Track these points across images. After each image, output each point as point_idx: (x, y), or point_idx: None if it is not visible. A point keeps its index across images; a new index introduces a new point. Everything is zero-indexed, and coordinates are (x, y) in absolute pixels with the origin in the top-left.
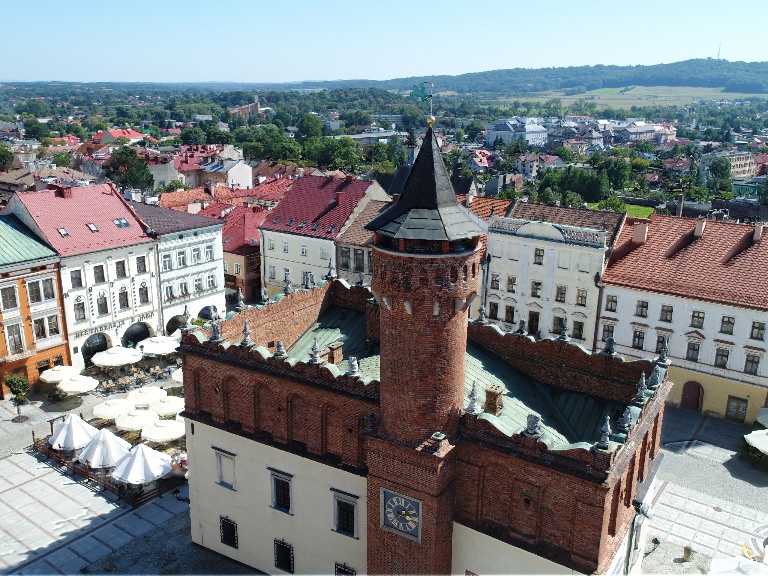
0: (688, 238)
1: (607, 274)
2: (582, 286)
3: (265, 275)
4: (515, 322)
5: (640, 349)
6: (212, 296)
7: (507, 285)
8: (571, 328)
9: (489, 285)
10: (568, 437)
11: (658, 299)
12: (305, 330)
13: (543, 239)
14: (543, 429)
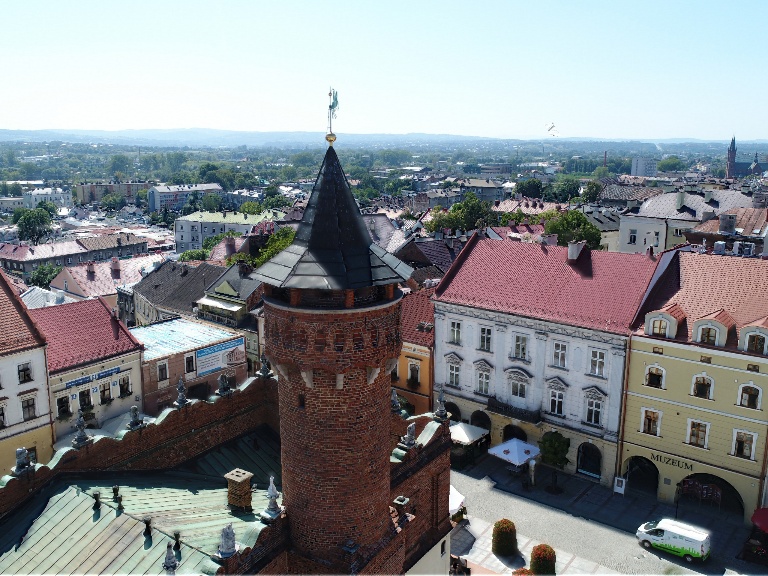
0: None
1: None
2: None
3: None
4: None
5: None
6: None
7: None
8: None
9: None
10: (259, 488)
11: None
12: None
13: None
14: (252, 494)
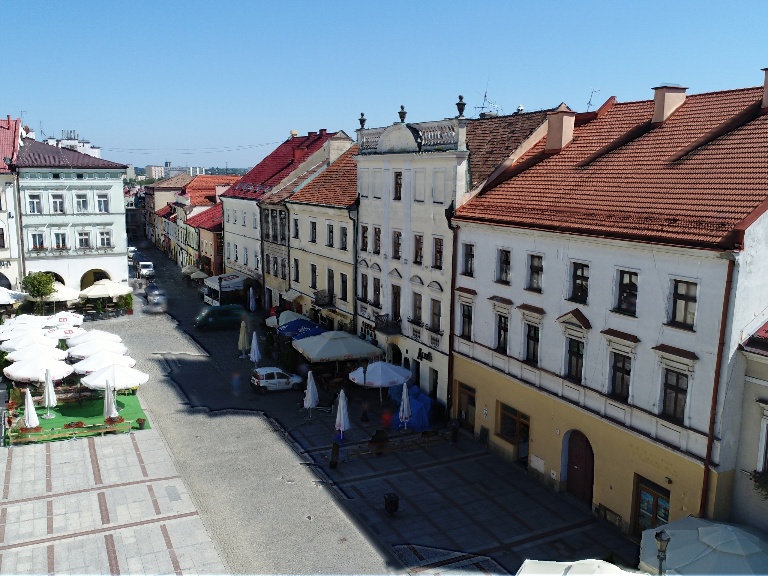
0: (638, 130)
1: (470, 204)
2: (437, 231)
3: (225, 255)
4: (380, 305)
5: (502, 353)
6: (106, 258)
7: (373, 242)
8: (428, 312)
9: (359, 245)
10: None
11: (522, 242)
12: None
13: None
14: None
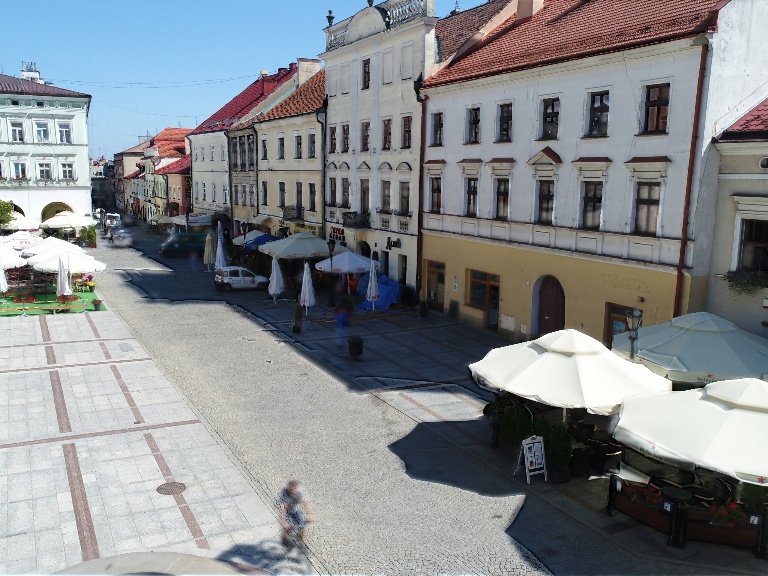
0: None
1: (439, 75)
2: (405, 108)
3: (193, 196)
4: (348, 205)
5: None
6: (68, 191)
7: (341, 141)
8: (397, 197)
9: (327, 148)
10: None
11: (491, 94)
12: None
13: (365, 37)
14: None
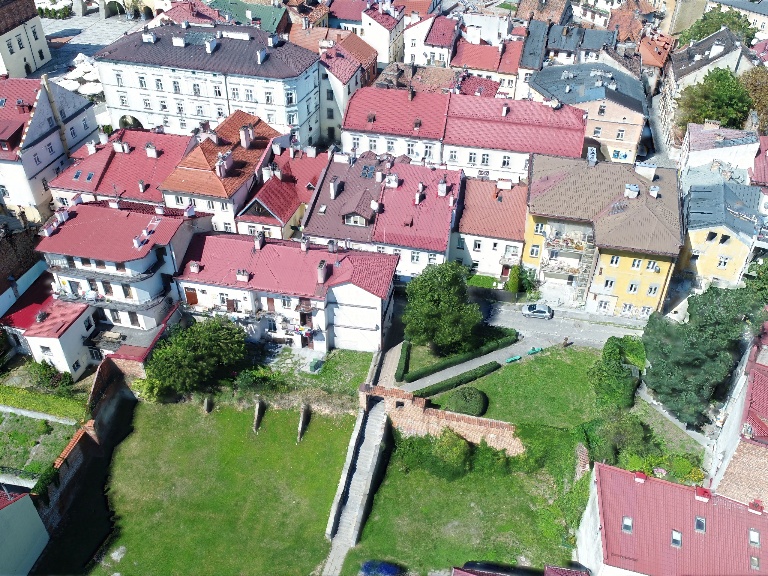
0: None
1: None
2: None
3: None
4: None
5: None
6: None
7: None
8: None
9: None
10: None
11: None
12: (1, 19)
13: None
14: None
